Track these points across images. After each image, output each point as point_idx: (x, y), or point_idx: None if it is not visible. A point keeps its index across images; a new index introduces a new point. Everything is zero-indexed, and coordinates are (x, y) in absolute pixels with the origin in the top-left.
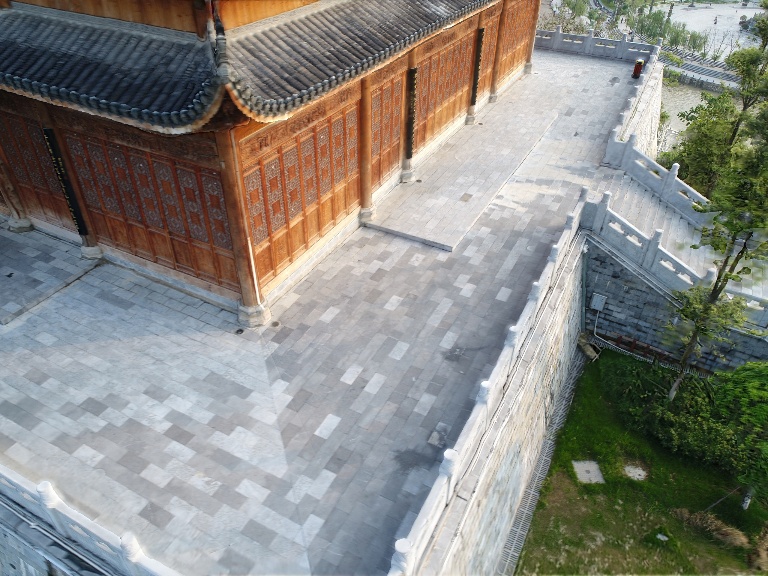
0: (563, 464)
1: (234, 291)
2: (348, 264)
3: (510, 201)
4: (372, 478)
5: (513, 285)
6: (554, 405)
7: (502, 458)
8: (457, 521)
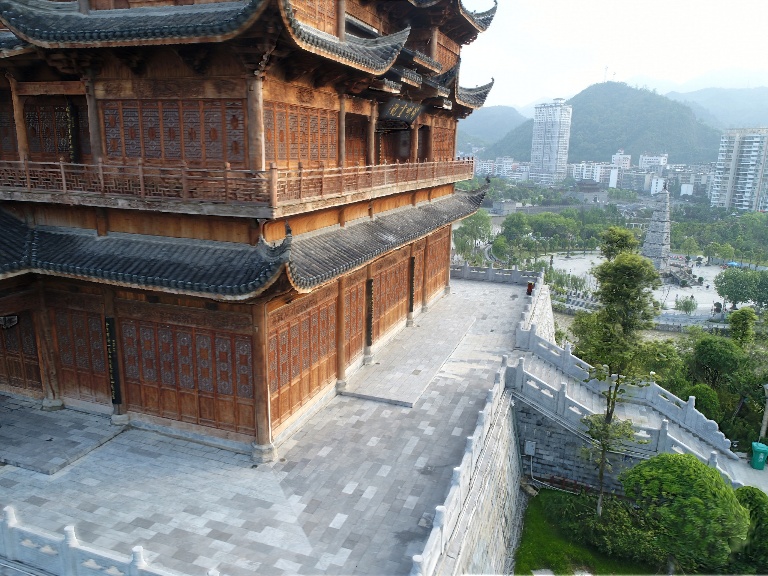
0: (524, 573)
1: (249, 435)
2: (332, 419)
3: (450, 374)
4: (380, 550)
5: (463, 426)
6: (509, 531)
7: (475, 545)
8: (450, 572)
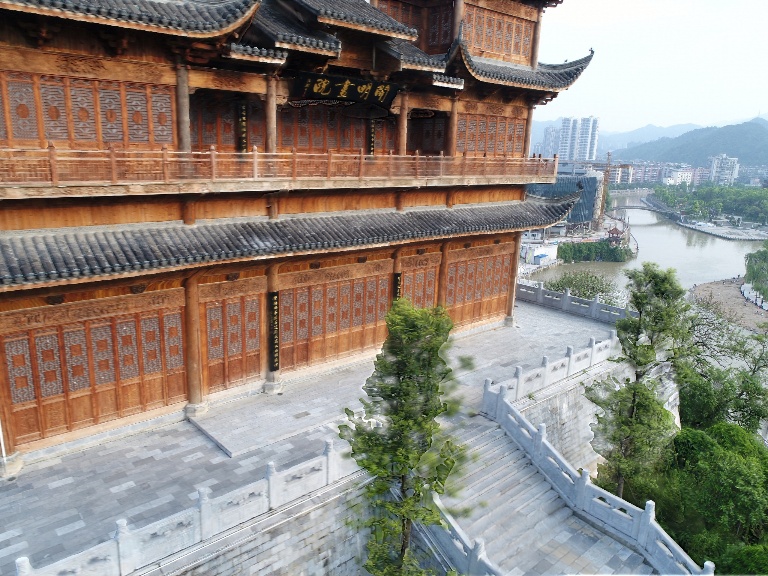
0: None
1: None
2: (133, 447)
3: None
4: None
5: None
6: None
7: None
8: None
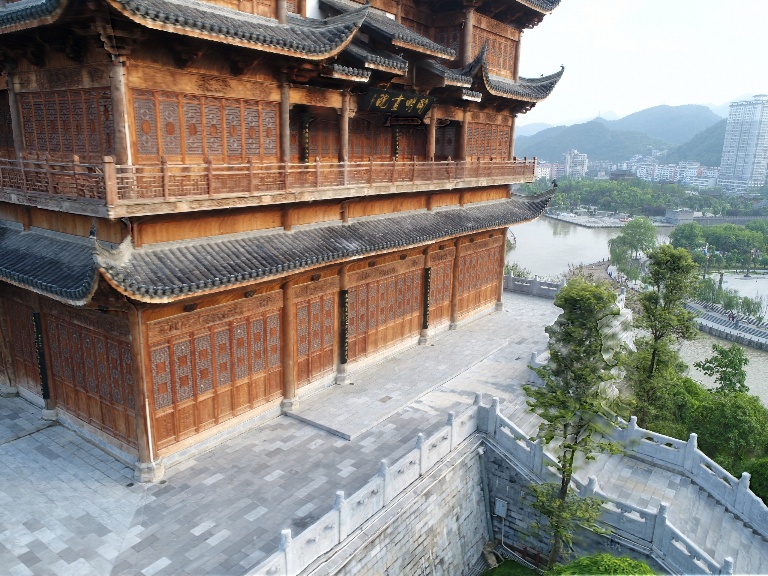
0: None
1: (137, 450)
2: (253, 442)
3: (426, 405)
4: None
5: None
6: None
7: None
8: None
